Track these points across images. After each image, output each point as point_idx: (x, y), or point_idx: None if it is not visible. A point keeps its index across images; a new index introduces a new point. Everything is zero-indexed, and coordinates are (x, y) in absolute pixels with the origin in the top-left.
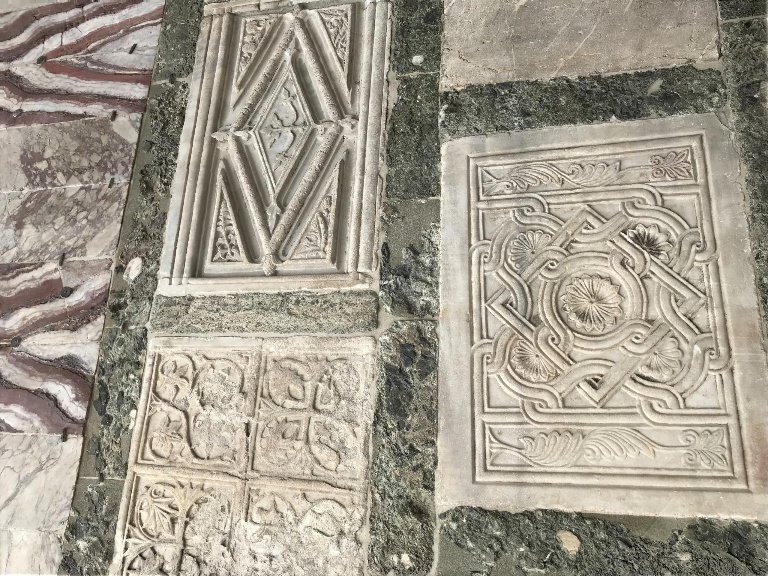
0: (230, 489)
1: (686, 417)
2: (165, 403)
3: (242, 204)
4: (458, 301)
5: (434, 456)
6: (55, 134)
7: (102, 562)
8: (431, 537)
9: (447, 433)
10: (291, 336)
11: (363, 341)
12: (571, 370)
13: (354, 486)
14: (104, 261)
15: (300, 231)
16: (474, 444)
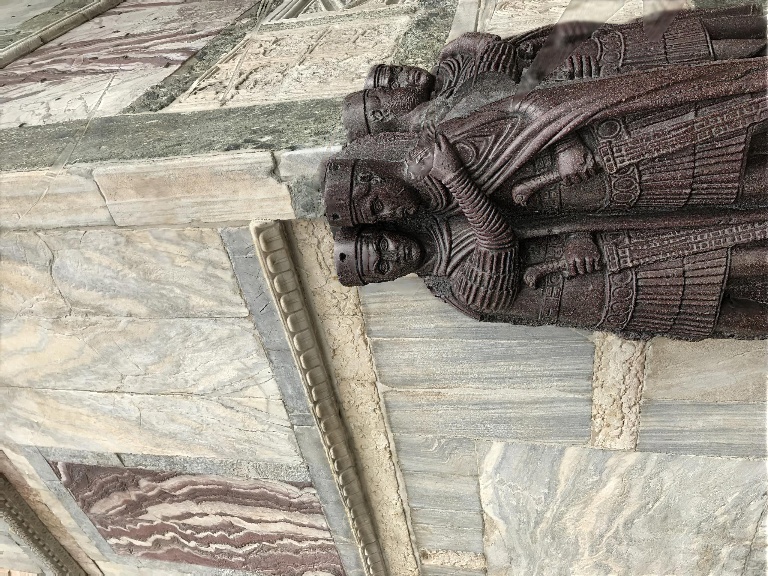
0: None
1: (624, 6)
2: None
3: (328, 6)
4: (471, 0)
5: None
6: (205, 4)
7: (177, 91)
8: None
9: None
10: None
11: None
12: None
13: None
14: (224, 23)
15: None
16: None
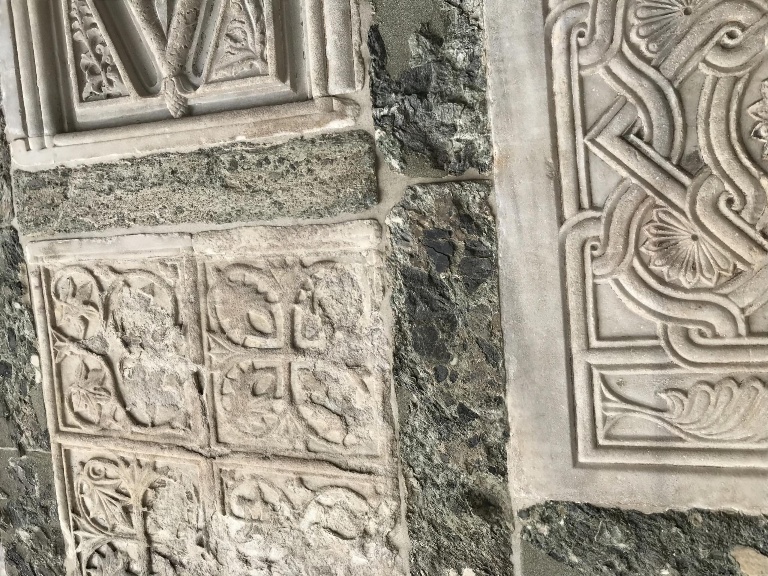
0: (193, 469)
1: None
2: (73, 344)
3: None
4: (528, 137)
5: (503, 422)
6: None
7: (53, 558)
8: (507, 543)
9: (523, 384)
10: (235, 227)
11: (357, 228)
12: (767, 262)
13: (375, 467)
14: None
15: (215, 21)
16: (573, 400)
